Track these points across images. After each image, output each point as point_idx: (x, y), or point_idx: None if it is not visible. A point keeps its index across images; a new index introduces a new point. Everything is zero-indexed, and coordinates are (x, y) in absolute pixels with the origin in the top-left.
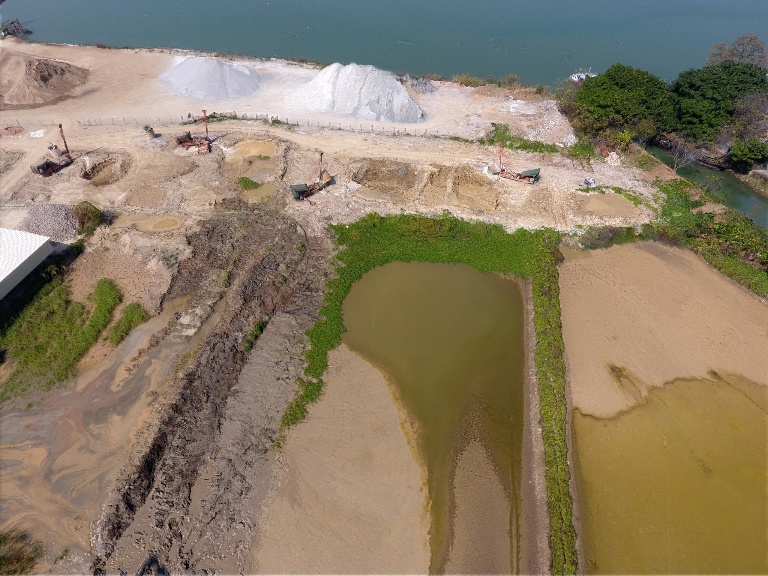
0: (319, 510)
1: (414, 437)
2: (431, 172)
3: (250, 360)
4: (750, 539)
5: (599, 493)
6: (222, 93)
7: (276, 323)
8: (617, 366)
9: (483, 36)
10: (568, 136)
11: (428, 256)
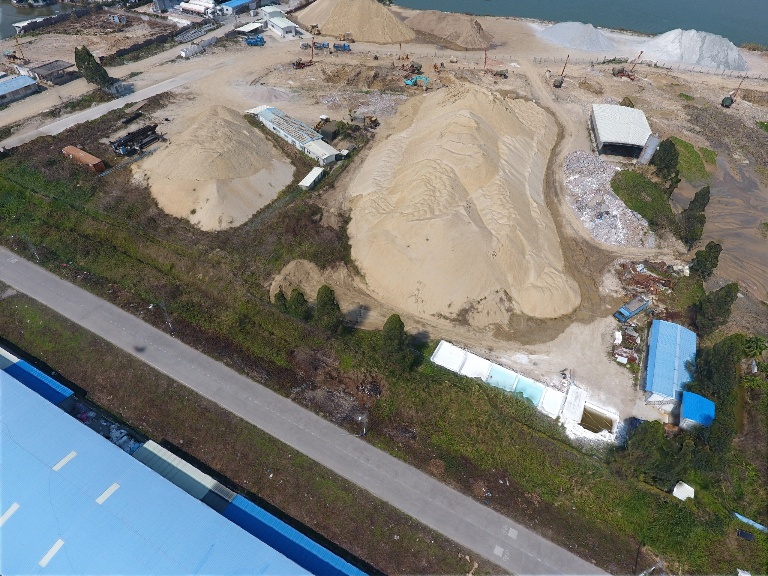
0: None
1: None
2: None
3: None
4: None
5: None
6: (599, 47)
7: None
8: None
9: None
10: None
11: None
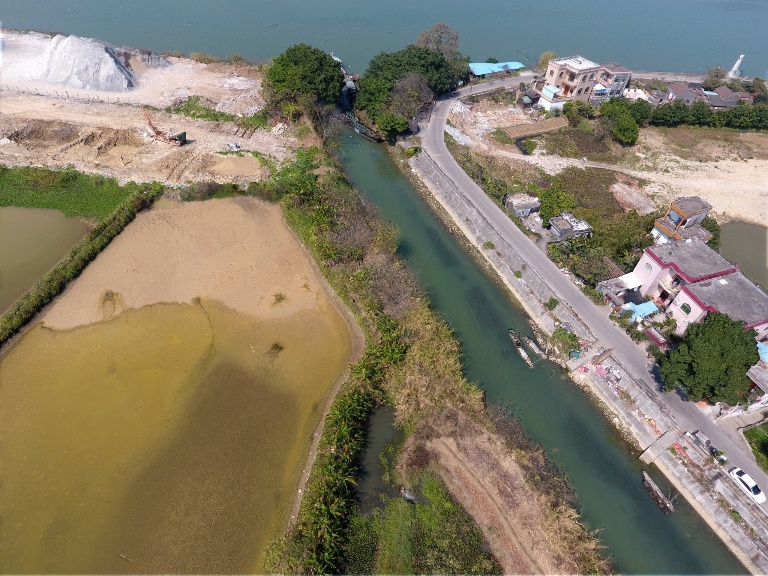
0: None
1: None
2: (93, 133)
3: None
4: (95, 420)
5: None
6: None
7: None
8: (113, 292)
9: None
10: (250, 108)
11: (26, 202)
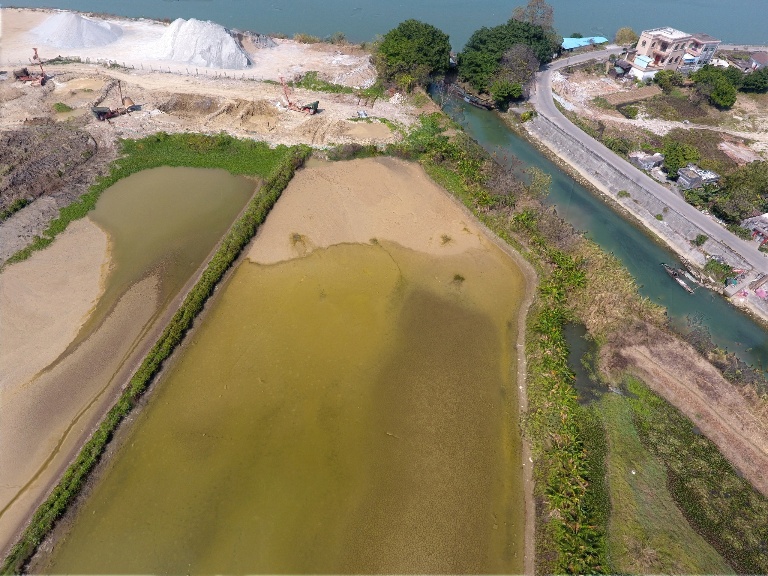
0: (6, 311)
1: (107, 272)
2: (231, 105)
3: (3, 224)
4: (324, 333)
5: (228, 306)
6: (78, 43)
7: (39, 203)
8: (299, 234)
9: (348, 6)
10: (366, 81)
11: (193, 163)
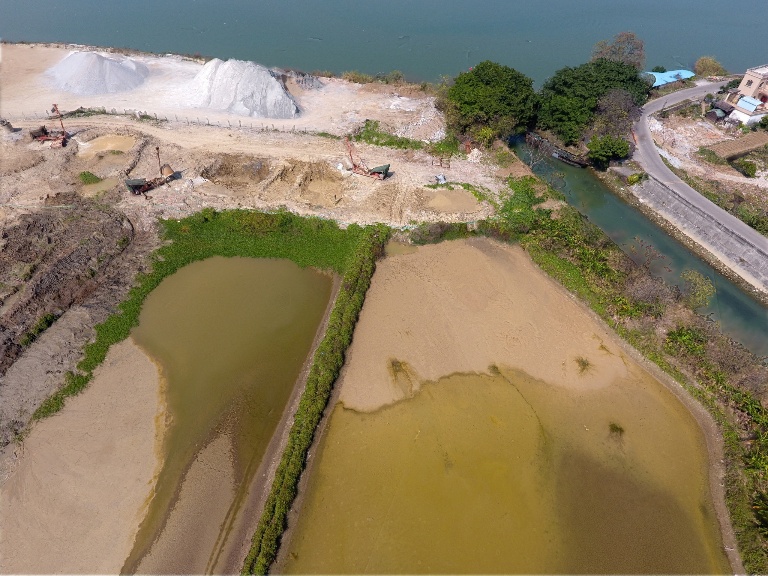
0: (36, 503)
1: (164, 430)
2: (285, 168)
3: (26, 353)
4: (464, 532)
5: (329, 486)
6: (100, 88)
7: (69, 317)
8: (399, 361)
9: None
10: (436, 133)
11: (251, 251)
